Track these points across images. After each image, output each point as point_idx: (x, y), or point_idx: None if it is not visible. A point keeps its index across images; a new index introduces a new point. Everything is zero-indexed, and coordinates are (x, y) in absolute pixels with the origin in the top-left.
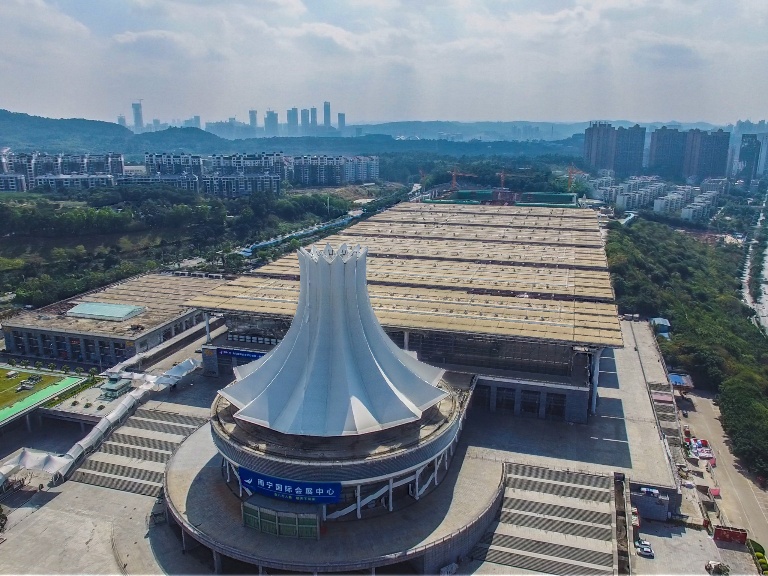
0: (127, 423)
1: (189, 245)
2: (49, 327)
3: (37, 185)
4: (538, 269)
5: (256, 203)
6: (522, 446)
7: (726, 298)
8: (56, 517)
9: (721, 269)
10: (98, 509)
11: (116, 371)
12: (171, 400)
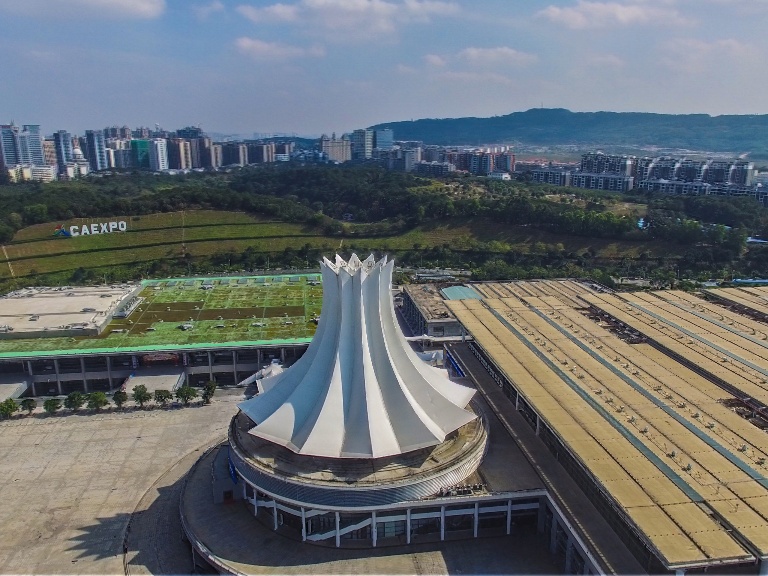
0: None
1: (672, 264)
2: (413, 296)
3: (637, 187)
4: None
5: None
6: None
7: None
8: None
9: None
10: None
11: None
12: None
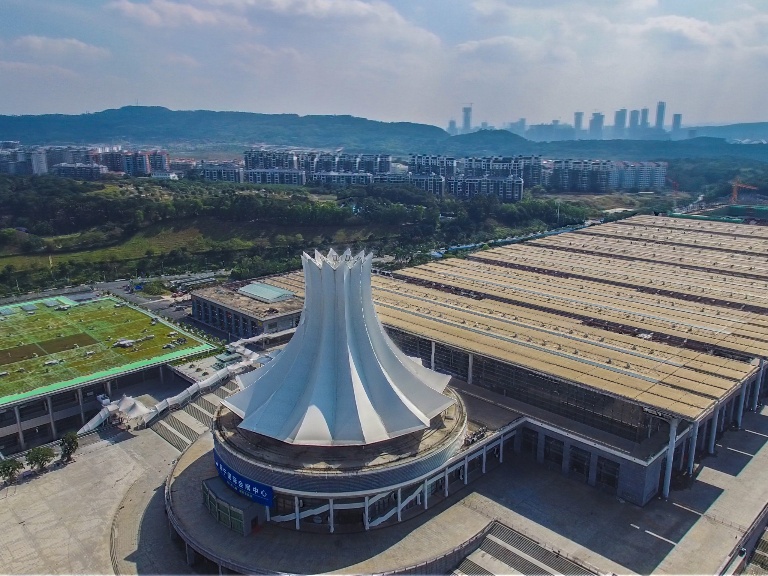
0: (216, 391)
1: (395, 242)
2: (216, 300)
3: (312, 180)
4: (704, 307)
5: (474, 206)
6: (533, 509)
7: None
8: (117, 454)
9: None
10: (147, 456)
11: (235, 345)
12: None
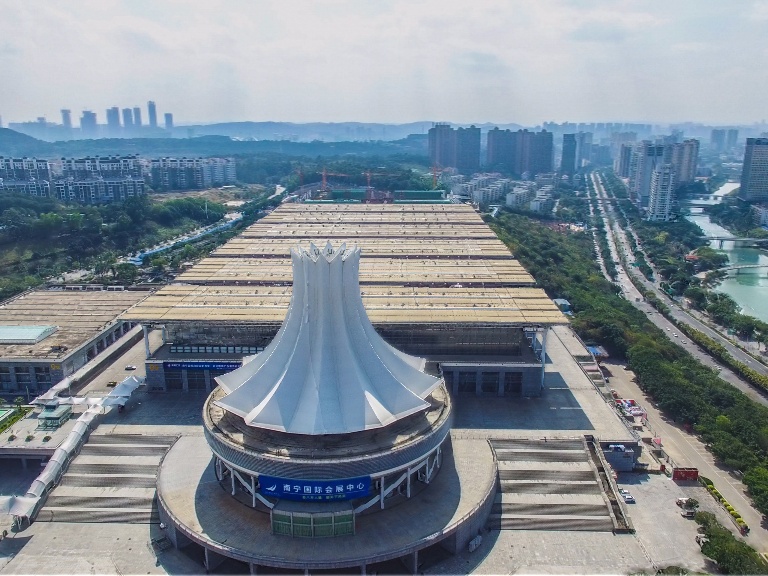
0: (83, 452)
1: (66, 257)
2: None
3: None
4: (457, 261)
5: (132, 209)
6: (496, 423)
7: (596, 278)
8: (40, 562)
9: (580, 254)
10: (87, 546)
11: (50, 398)
12: (125, 422)
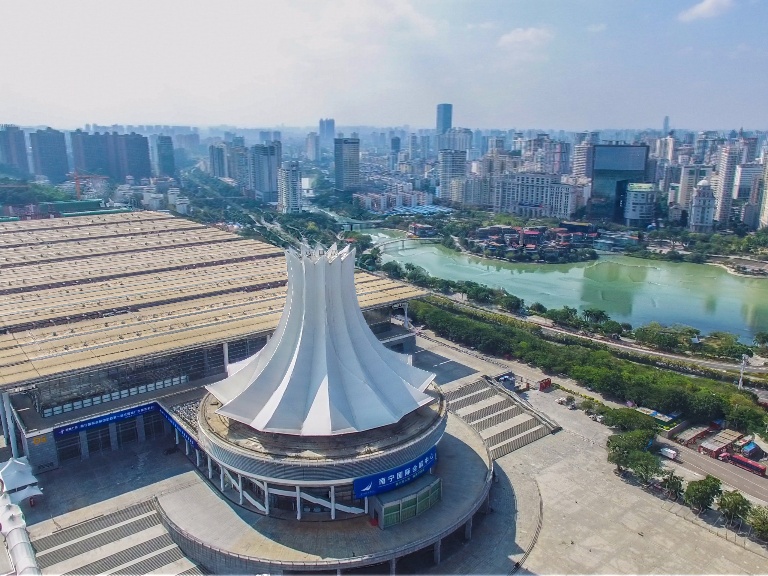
0: (43, 563)
1: None
2: None
3: None
4: (256, 262)
5: None
6: None
7: None
8: None
9: None
10: None
11: None
12: (57, 512)
